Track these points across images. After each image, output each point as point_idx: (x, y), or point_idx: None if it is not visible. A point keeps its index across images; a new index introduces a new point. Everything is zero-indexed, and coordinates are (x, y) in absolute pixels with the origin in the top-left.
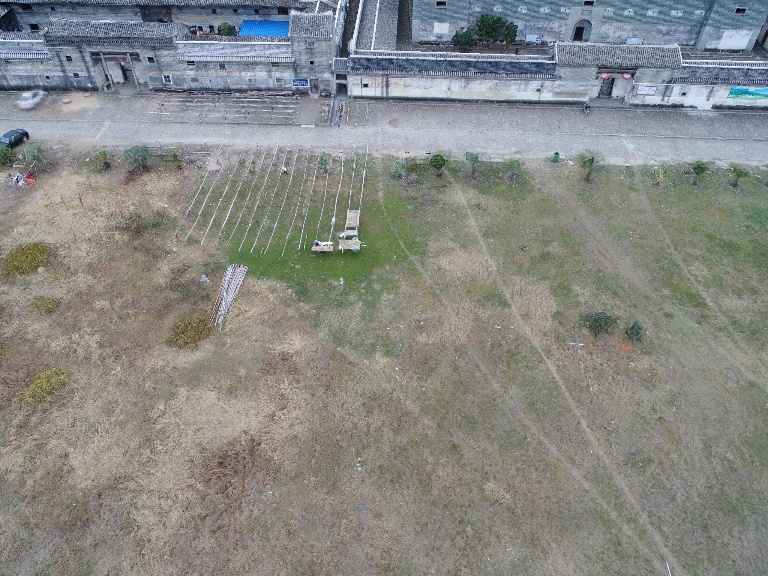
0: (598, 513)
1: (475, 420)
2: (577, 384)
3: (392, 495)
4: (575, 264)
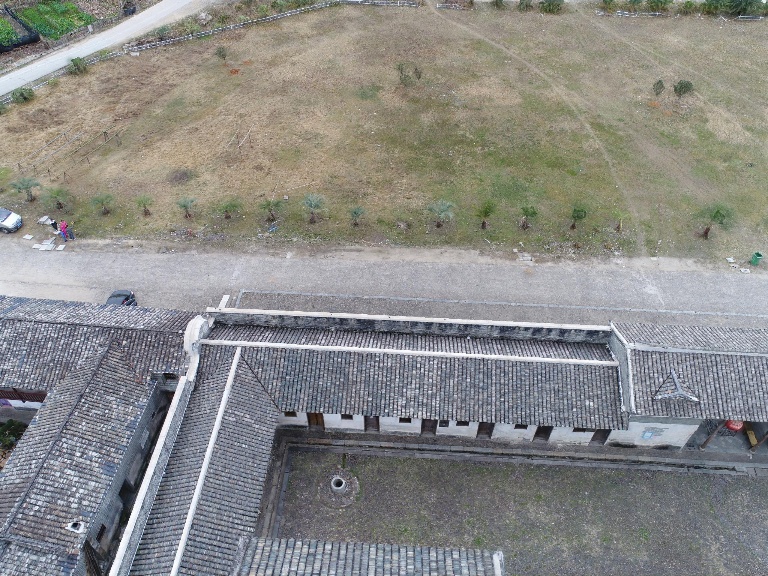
0: (665, 55)
1: (739, 79)
2: None
3: (767, 60)
4: (699, 153)
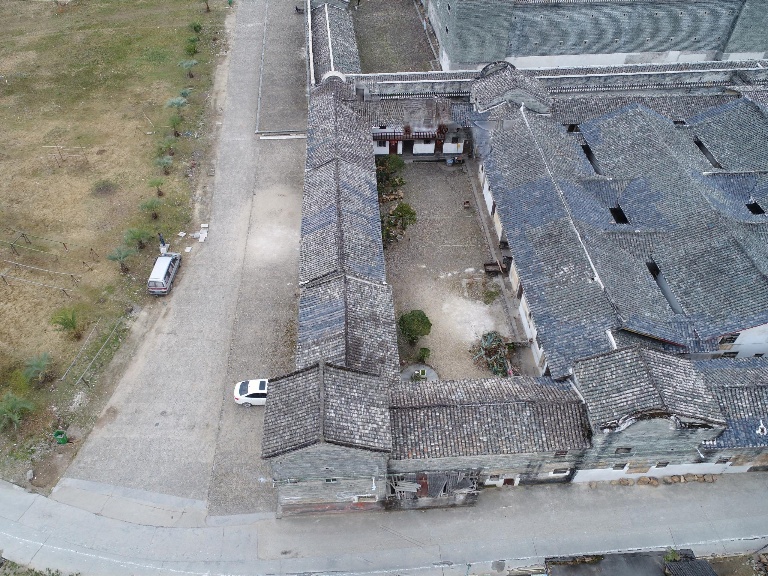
0: None
1: None
2: (44, 1)
3: None
4: (126, 5)
